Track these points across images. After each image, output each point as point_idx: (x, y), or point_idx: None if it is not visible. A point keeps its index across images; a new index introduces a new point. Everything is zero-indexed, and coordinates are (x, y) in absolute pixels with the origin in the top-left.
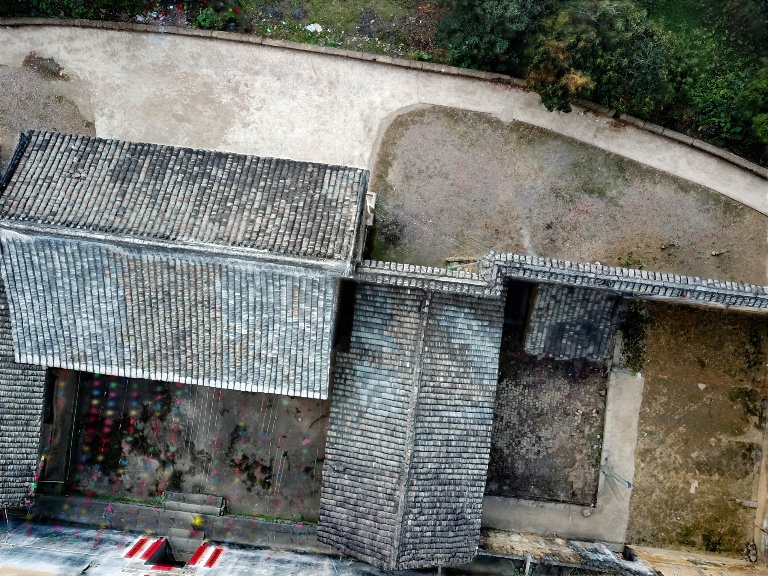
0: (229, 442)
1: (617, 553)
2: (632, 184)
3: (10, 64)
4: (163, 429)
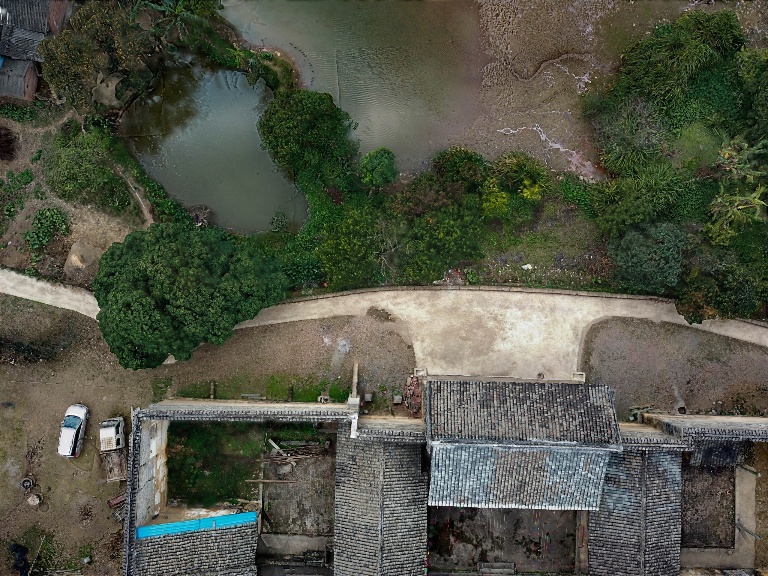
0: (514, 530)
1: (751, 575)
2: (735, 353)
3: (359, 315)
4: (473, 525)
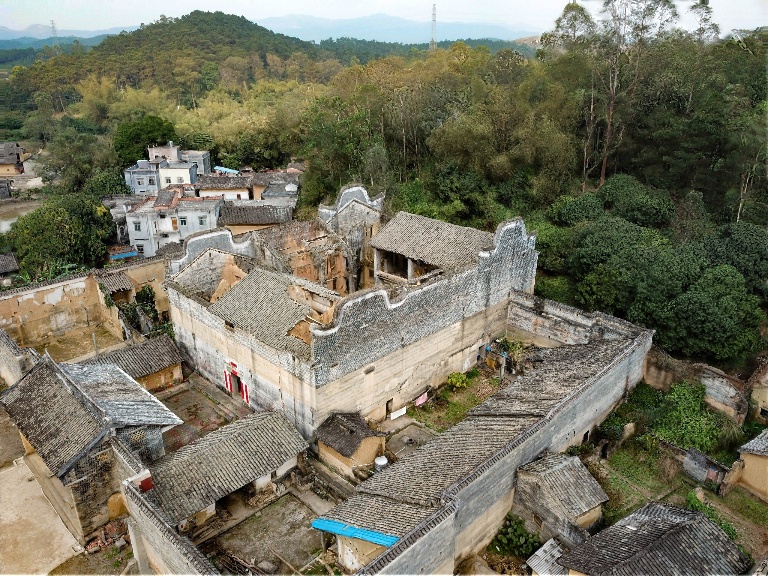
0: (188, 422)
1: None
2: None
3: None
4: None
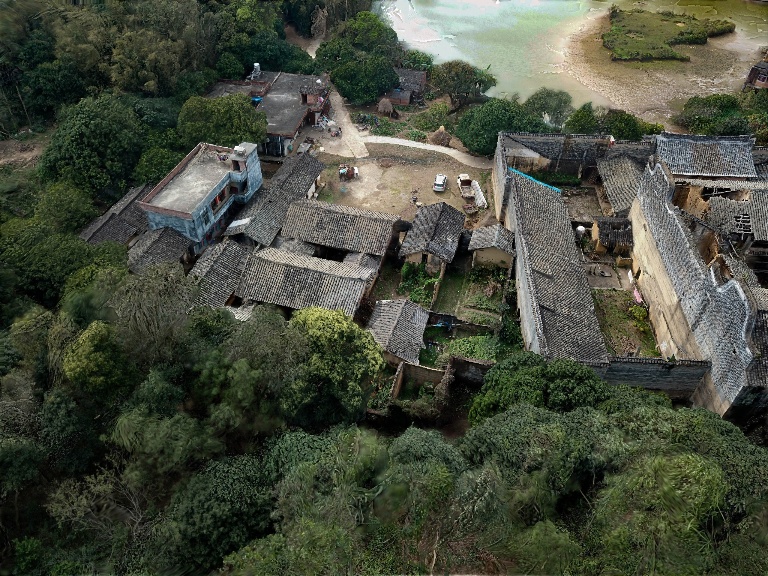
0: None
1: None
2: None
3: None
4: None
